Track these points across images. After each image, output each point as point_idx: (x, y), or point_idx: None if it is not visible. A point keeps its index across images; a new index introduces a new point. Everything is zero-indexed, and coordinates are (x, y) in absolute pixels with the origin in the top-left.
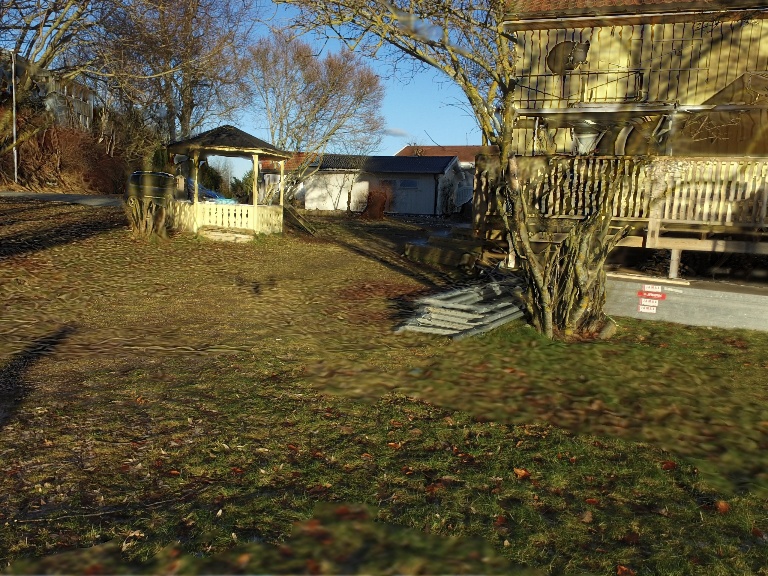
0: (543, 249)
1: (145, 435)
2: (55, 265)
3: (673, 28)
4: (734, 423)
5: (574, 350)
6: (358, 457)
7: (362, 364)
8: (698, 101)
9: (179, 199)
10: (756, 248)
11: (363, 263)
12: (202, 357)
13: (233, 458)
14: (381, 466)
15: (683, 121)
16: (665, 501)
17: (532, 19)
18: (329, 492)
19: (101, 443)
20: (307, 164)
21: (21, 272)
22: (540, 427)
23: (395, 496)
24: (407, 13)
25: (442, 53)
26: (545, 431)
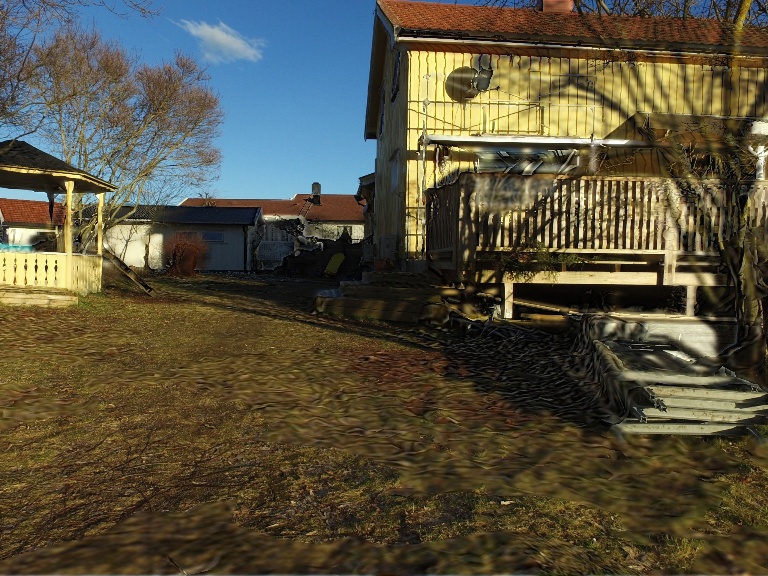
0: (549, 292)
1: None
2: None
3: (569, 63)
4: None
5: None
6: None
7: None
8: (596, 138)
9: None
10: None
11: (286, 325)
12: None
13: None
14: None
15: (589, 157)
16: None
17: (431, 37)
18: None
19: None
20: (119, 203)
21: None
22: None
23: None
24: None
25: None
26: None
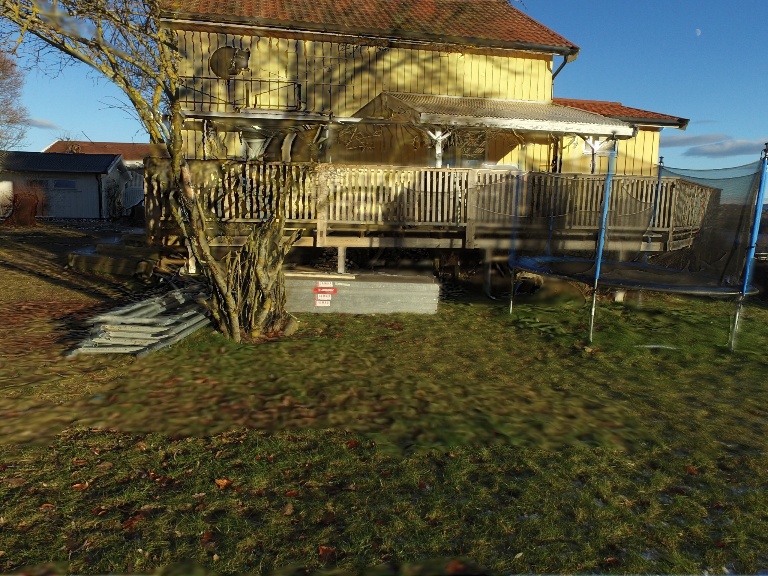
0: (223, 253)
1: None
2: None
3: (322, 46)
4: (398, 396)
5: (262, 351)
6: (36, 511)
7: (28, 401)
8: (348, 114)
9: None
10: (402, 243)
11: (15, 279)
12: None
13: None
14: (67, 514)
15: (338, 131)
16: (352, 477)
17: (191, 20)
18: (2, 561)
19: None
20: None
21: None
22: (237, 433)
23: (88, 543)
24: (50, 3)
25: (97, 53)
26: (242, 436)
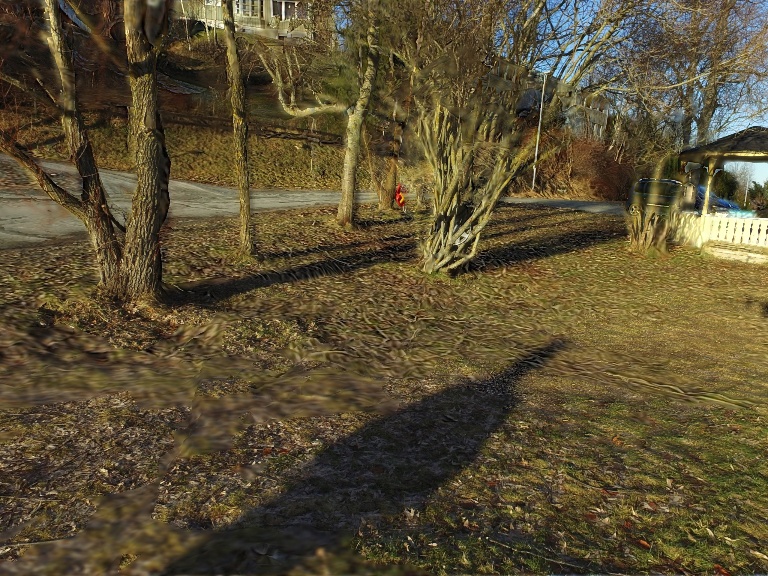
0: None
1: (617, 485)
2: (554, 273)
3: None
4: None
5: None
6: None
7: None
8: None
9: (684, 208)
10: None
11: None
12: (691, 404)
13: (718, 551)
14: None
15: None
16: None
17: None
18: None
19: (572, 479)
20: None
21: (525, 277)
22: None
23: None
24: None
25: None
26: None
